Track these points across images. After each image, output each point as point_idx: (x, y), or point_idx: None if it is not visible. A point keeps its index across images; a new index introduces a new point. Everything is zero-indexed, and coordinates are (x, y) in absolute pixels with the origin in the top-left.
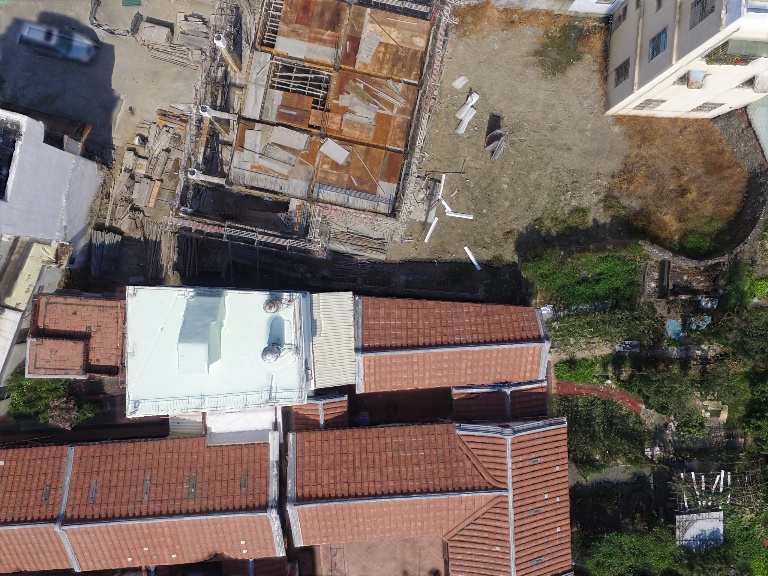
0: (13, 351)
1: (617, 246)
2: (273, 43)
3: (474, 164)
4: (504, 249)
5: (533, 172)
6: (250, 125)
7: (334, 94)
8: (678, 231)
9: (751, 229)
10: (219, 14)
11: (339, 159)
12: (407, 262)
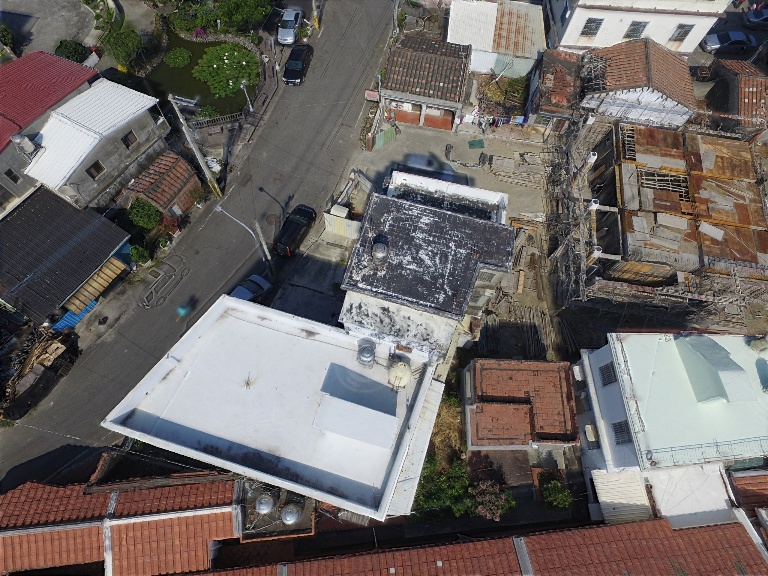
0: None
1: None
2: (634, 158)
3: None
4: None
5: None
6: (634, 213)
7: (694, 190)
8: None
9: None
10: (546, 152)
11: (717, 236)
12: None
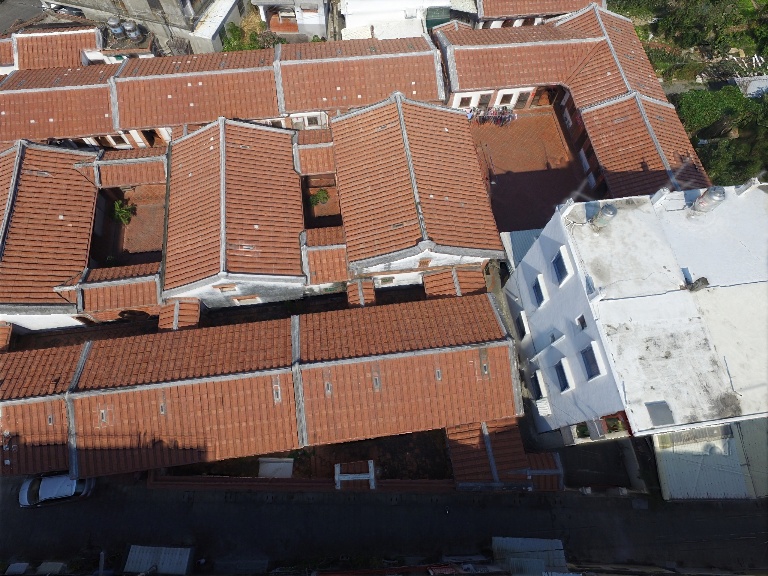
0: (235, 8)
1: None
2: None
3: None
4: None
5: None
6: None
7: None
8: None
9: None
10: None
11: None
12: None
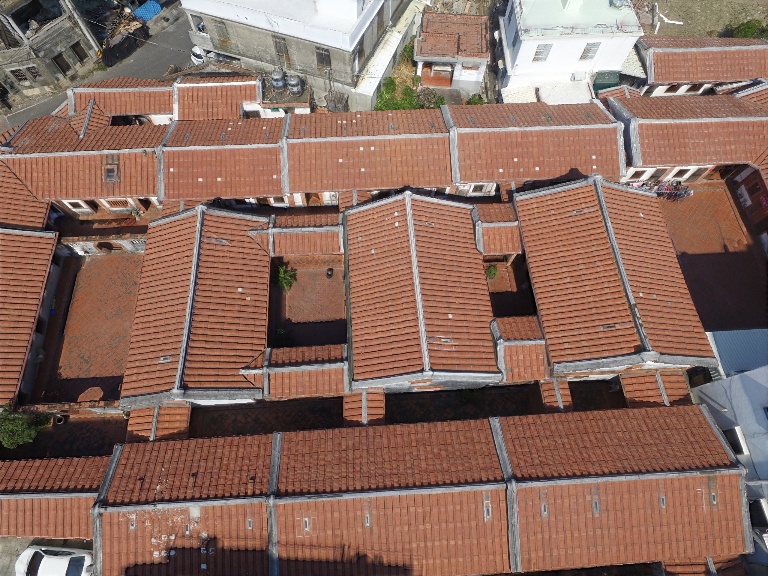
0: (391, 61)
1: None
2: None
3: (673, 0)
4: None
5: (714, 4)
6: None
7: None
8: None
9: None
10: None
11: None
12: None
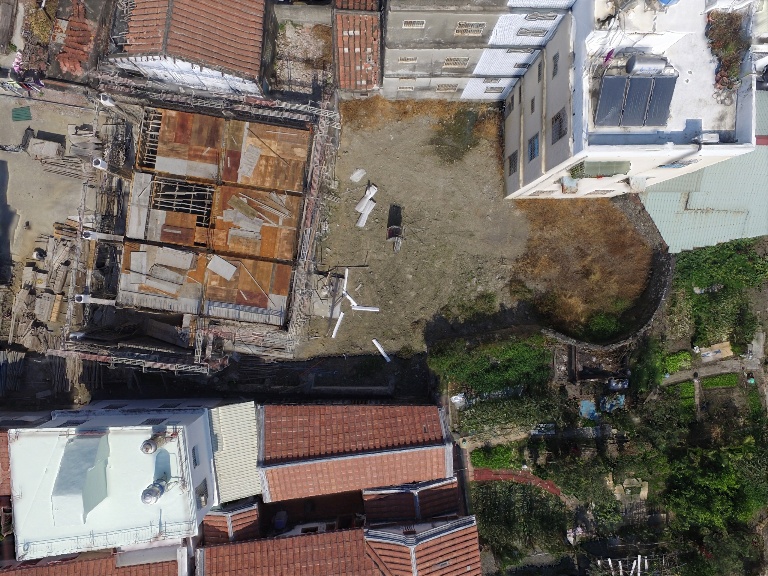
0: None
1: (522, 334)
2: (153, 163)
3: (377, 256)
4: (413, 339)
5: (437, 260)
6: (135, 247)
7: (218, 210)
8: (585, 312)
9: (654, 310)
10: (110, 124)
11: (227, 275)
12: (316, 358)
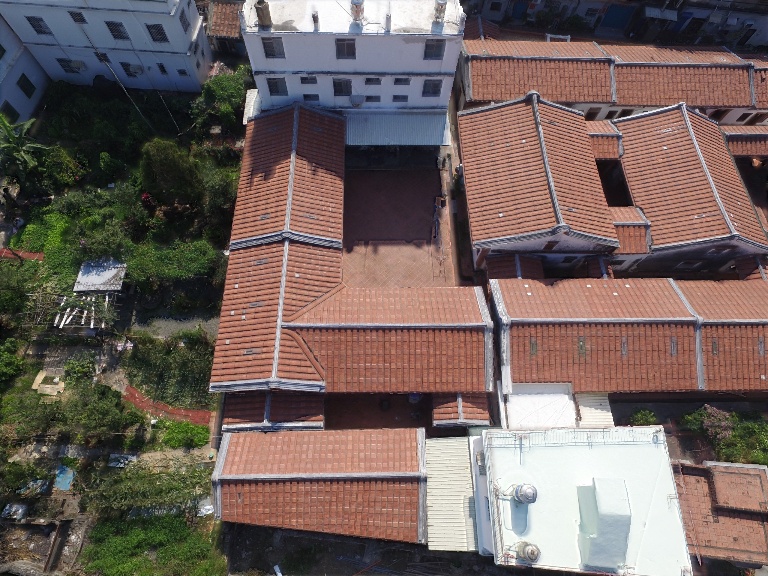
0: None
1: None
2: None
3: None
4: None
5: None
6: None
7: None
8: None
9: None
10: None
11: None
12: None
